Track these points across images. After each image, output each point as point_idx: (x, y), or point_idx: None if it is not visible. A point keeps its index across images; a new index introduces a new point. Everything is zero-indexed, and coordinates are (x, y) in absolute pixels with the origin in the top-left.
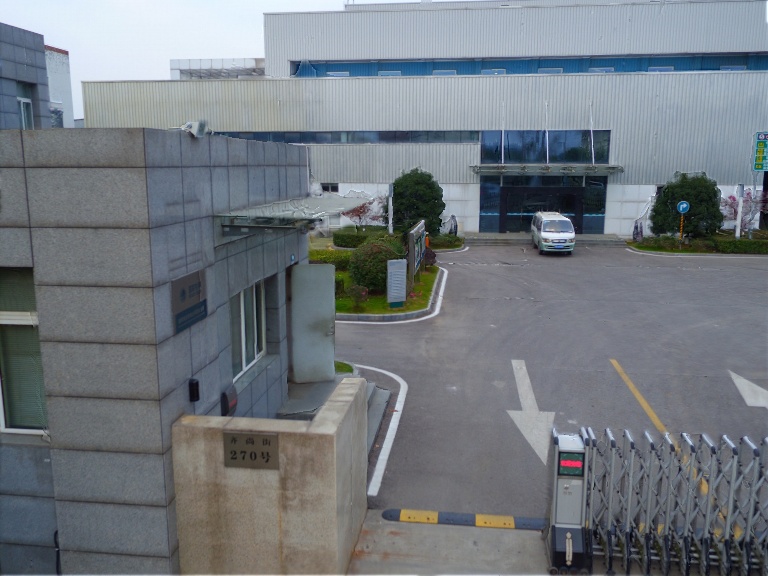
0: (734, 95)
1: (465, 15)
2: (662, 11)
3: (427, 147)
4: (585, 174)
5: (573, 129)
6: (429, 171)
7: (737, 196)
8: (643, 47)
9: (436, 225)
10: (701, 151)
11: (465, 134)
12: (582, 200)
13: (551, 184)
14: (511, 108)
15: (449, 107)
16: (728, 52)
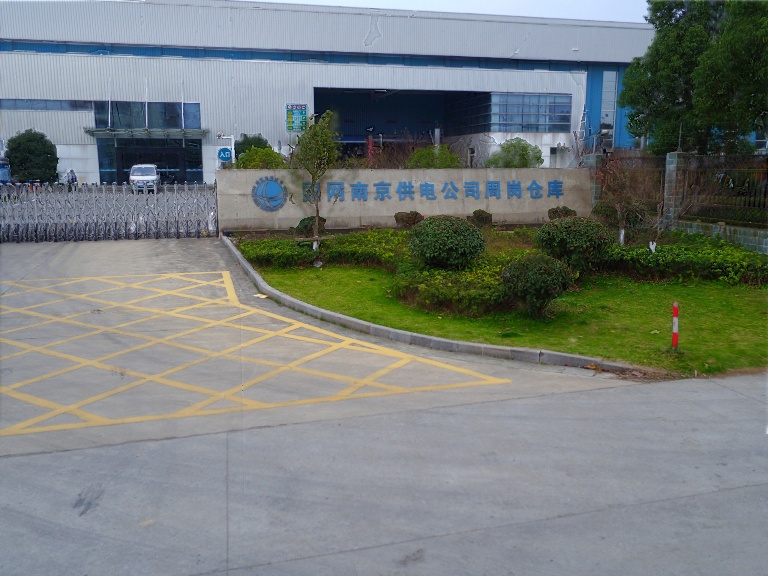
0: (287, 79)
1: (90, 5)
2: (255, 15)
3: (46, 113)
4: (184, 137)
5: (170, 101)
6: (50, 134)
7: (278, 149)
8: (243, 42)
9: (49, 175)
10: (269, 120)
11: (80, 103)
12: (185, 158)
13: (157, 145)
14: (117, 83)
15: (63, 80)
16: (307, 50)
